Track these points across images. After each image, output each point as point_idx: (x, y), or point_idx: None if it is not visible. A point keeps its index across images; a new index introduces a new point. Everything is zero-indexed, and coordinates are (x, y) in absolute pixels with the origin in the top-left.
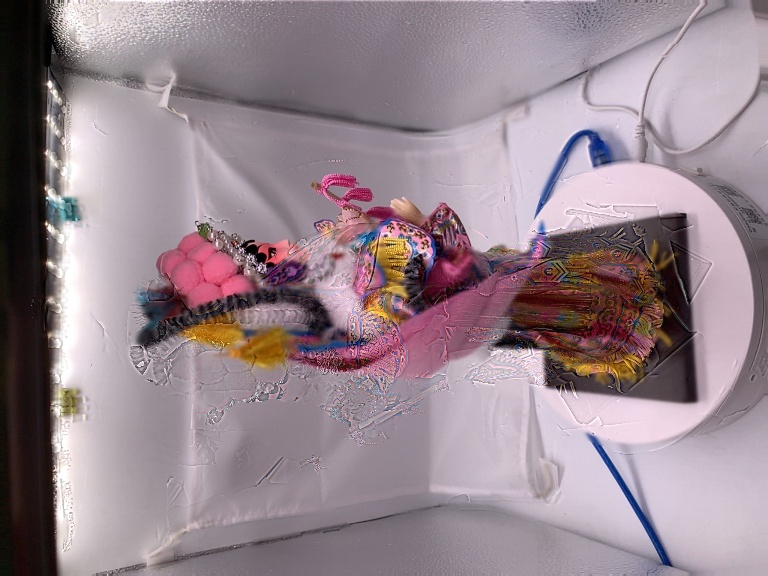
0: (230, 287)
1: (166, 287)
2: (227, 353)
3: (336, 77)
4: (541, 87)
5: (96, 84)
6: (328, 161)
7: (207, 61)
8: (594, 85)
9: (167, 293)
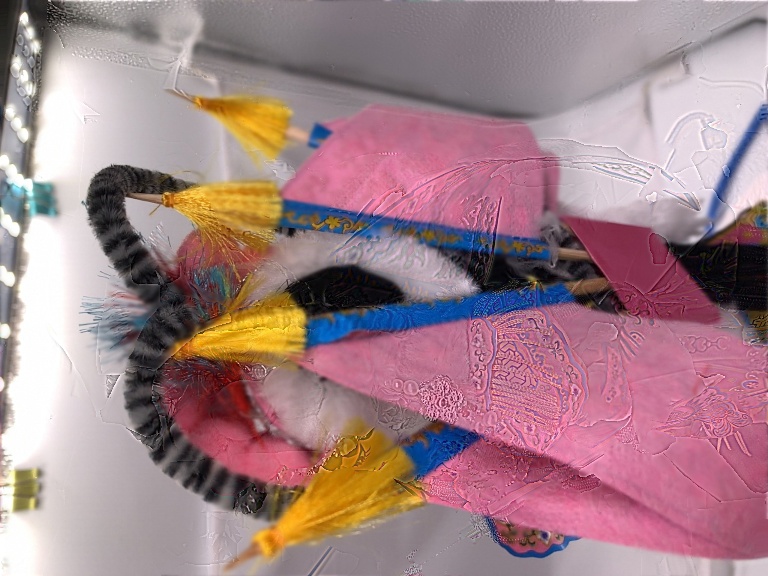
0: (282, 260)
1: (165, 255)
2: (275, 383)
3: (387, 48)
4: (636, 63)
5: (85, 62)
6: (378, 154)
7: (225, 29)
8: (704, 57)
9: (167, 268)
